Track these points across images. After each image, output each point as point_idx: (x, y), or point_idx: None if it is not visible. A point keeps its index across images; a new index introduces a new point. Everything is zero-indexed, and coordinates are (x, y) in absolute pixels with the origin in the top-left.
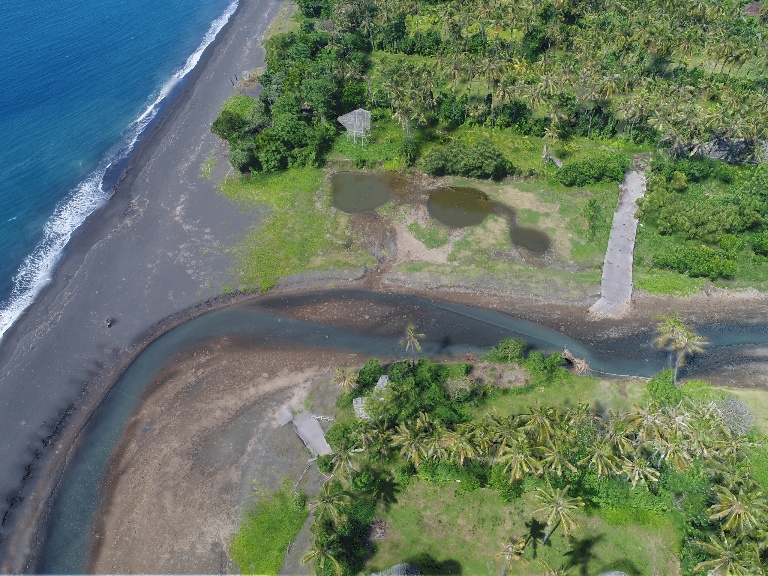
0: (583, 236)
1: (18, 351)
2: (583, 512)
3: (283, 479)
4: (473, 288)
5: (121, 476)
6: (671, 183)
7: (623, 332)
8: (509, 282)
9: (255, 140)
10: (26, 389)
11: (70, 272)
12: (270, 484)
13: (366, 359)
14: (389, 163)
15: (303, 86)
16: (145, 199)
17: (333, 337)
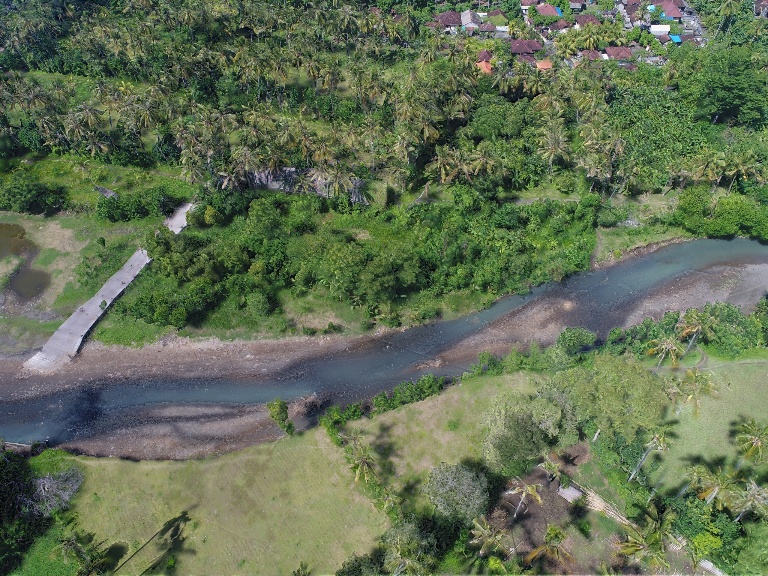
0: (83, 279)
1: None
2: None
3: None
4: None
5: None
6: None
7: (42, 391)
8: None
9: None
10: None
11: None
12: None
13: None
14: None
15: None
16: None
17: None
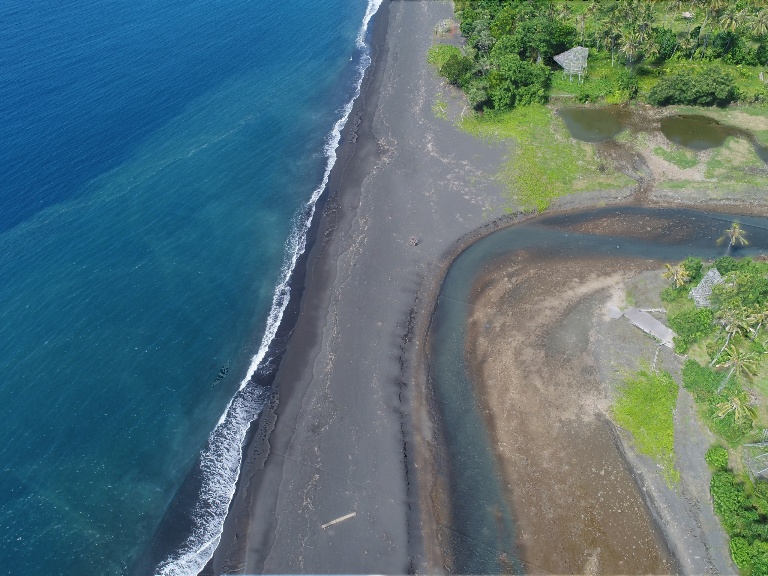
0: None
1: (341, 268)
2: None
3: (639, 361)
4: (742, 200)
5: (483, 365)
6: None
7: None
8: None
9: (486, 80)
10: (368, 297)
11: (353, 203)
12: (629, 365)
13: (665, 263)
14: (611, 97)
15: (520, 28)
16: (392, 139)
17: (624, 247)
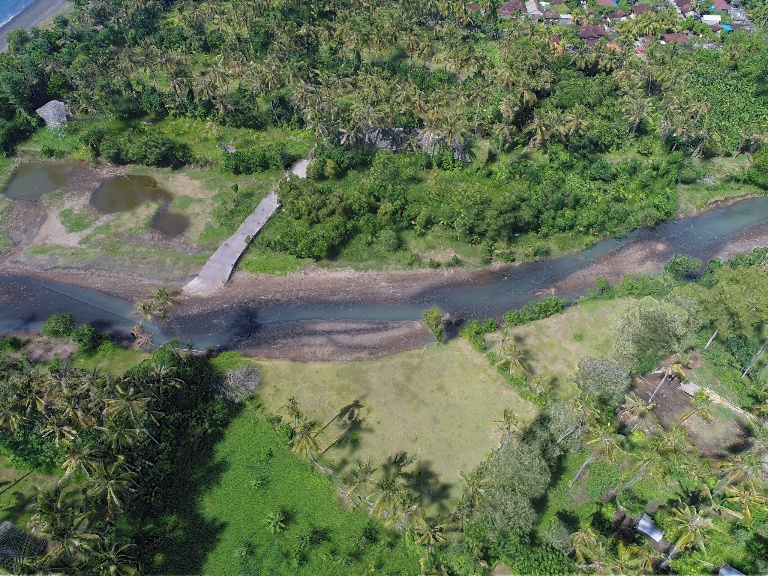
0: None
1: None
2: (42, 471)
3: None
4: (84, 269)
5: None
6: (324, 170)
7: (204, 309)
8: (120, 263)
9: None
10: None
11: None
12: None
13: None
14: (76, 153)
15: None
16: None
17: None
